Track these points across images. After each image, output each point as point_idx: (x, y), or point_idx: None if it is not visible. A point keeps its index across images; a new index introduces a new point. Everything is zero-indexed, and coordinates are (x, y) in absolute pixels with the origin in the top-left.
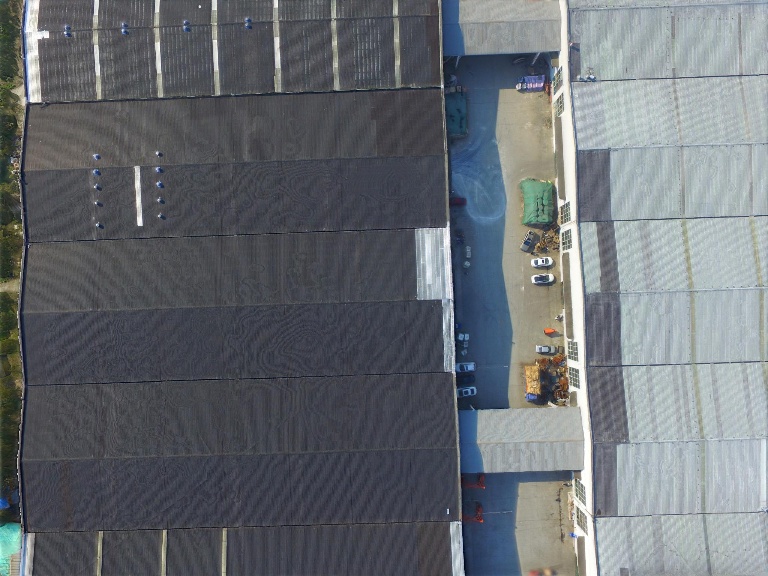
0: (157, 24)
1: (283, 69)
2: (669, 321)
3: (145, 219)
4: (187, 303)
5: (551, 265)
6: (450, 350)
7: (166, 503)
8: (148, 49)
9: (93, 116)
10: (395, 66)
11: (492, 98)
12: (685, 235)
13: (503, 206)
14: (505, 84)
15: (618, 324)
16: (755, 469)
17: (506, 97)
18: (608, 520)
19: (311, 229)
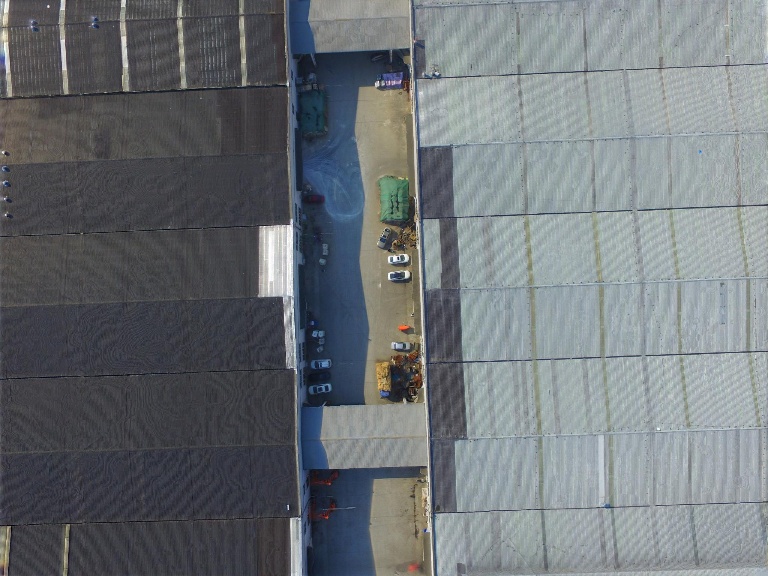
0: (6, 24)
1: (130, 68)
2: (509, 317)
3: None
4: (31, 301)
5: (408, 262)
6: (292, 347)
7: (10, 500)
8: None
9: None
10: (241, 64)
11: (352, 96)
12: (527, 231)
13: (361, 203)
14: (365, 82)
15: (459, 320)
16: (593, 465)
17: (366, 95)
18: (447, 516)
19: (156, 227)
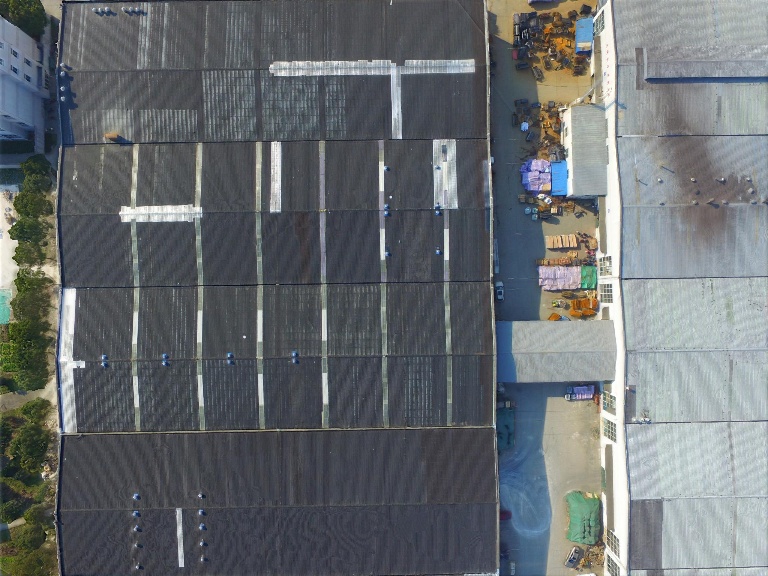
0: (200, 356)
1: (331, 405)
2: None
3: (187, 560)
4: None
5: None
6: None
7: None
8: (190, 381)
9: (132, 450)
10: (447, 404)
11: (540, 406)
12: None
13: (548, 519)
14: (553, 392)
15: None
16: None
17: (554, 405)
18: None
19: (358, 573)
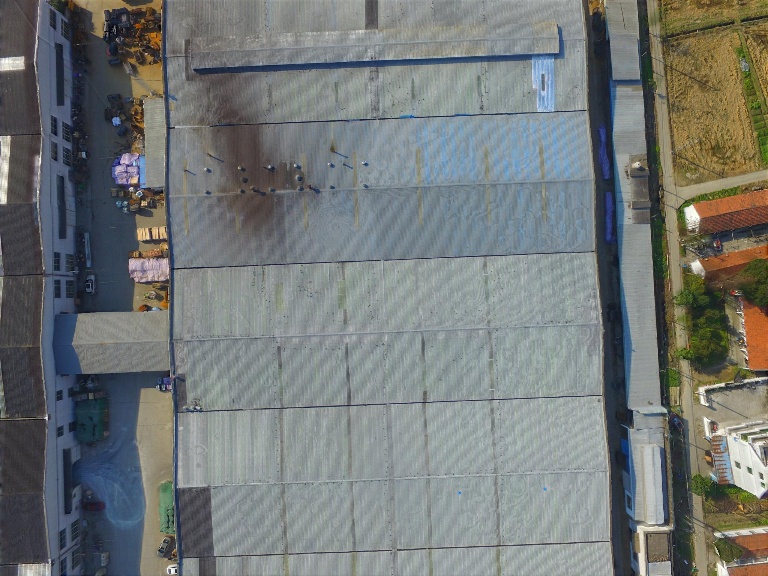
0: None
1: None
2: None
3: None
4: None
5: None
6: None
7: None
8: None
9: None
10: None
11: (133, 398)
12: (286, 572)
13: (142, 509)
14: (147, 383)
15: None
16: None
17: (148, 396)
18: None
19: None
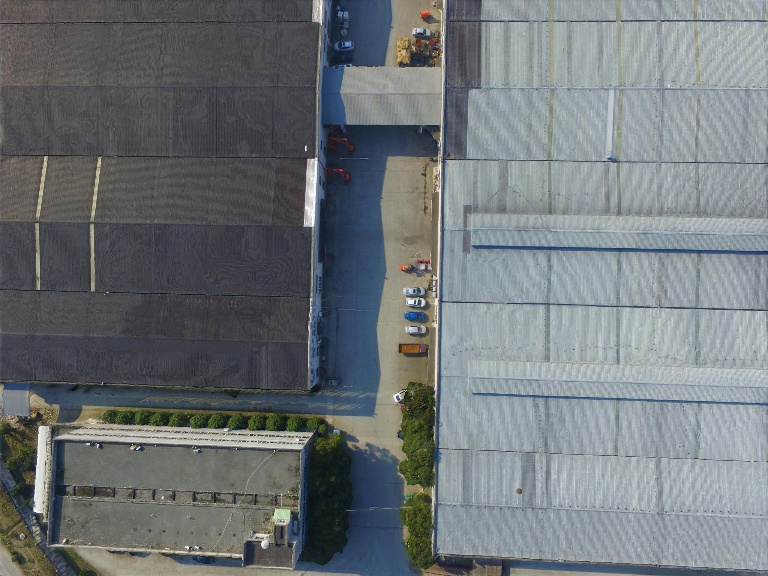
0: None
1: None
2: None
3: None
4: None
5: None
6: (319, 1)
7: (48, 131)
8: None
9: None
10: None
11: None
12: None
13: None
14: None
15: None
16: (602, 119)
17: None
18: (457, 162)
19: None
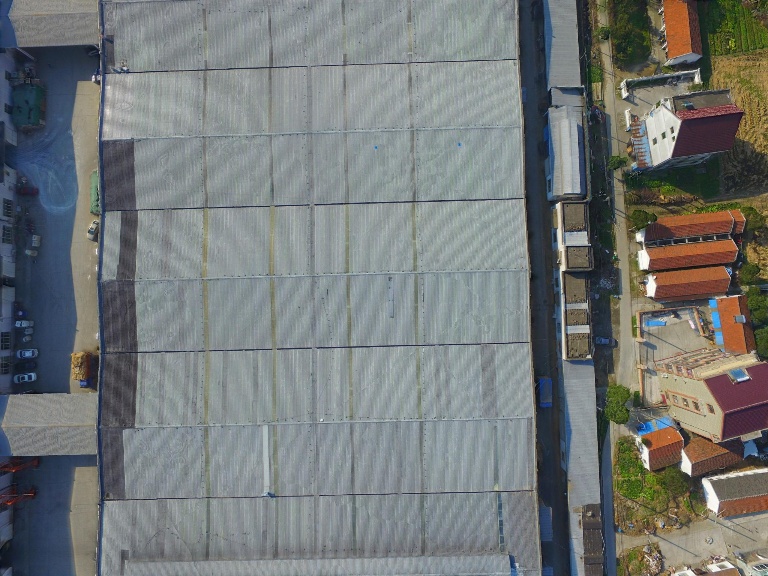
0: None
1: None
2: (182, 309)
3: None
4: None
5: None
6: None
7: None
8: None
9: None
10: None
11: (70, 90)
12: (206, 224)
13: (75, 196)
14: (83, 76)
15: (134, 311)
16: (258, 454)
17: (84, 89)
18: (115, 503)
19: None
